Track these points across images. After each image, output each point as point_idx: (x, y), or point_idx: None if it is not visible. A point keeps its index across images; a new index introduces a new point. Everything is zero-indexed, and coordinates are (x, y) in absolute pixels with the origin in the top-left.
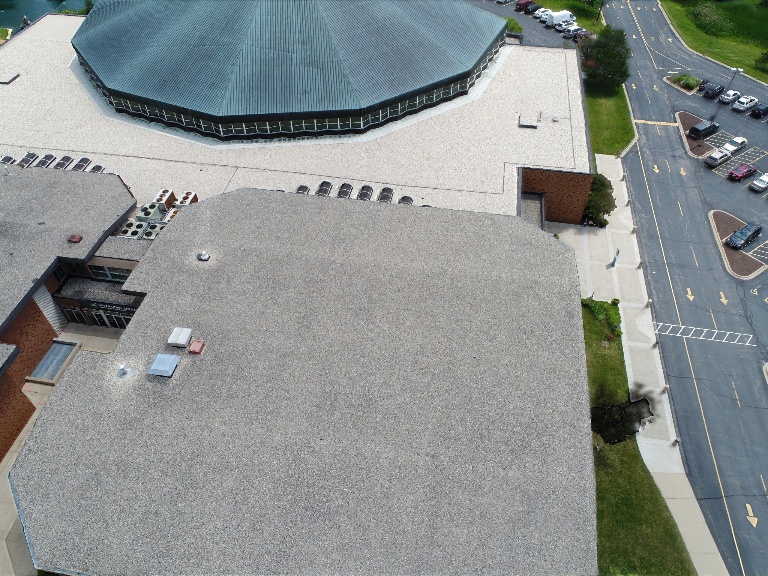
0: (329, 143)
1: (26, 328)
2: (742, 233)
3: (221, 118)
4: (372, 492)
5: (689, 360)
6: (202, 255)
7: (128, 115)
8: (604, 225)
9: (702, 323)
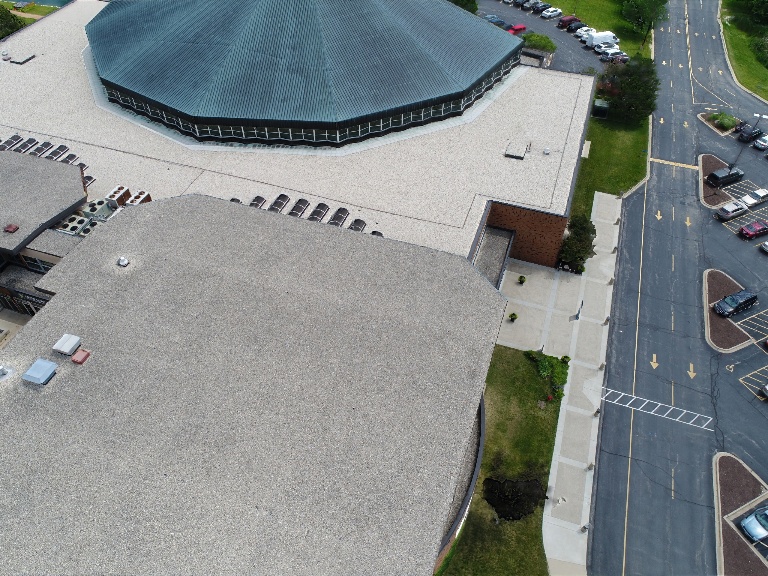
0: (302, 154)
1: None
2: (732, 300)
3: (196, 118)
4: (197, 541)
5: (630, 436)
6: (120, 260)
7: (119, 106)
8: (580, 272)
9: (658, 396)
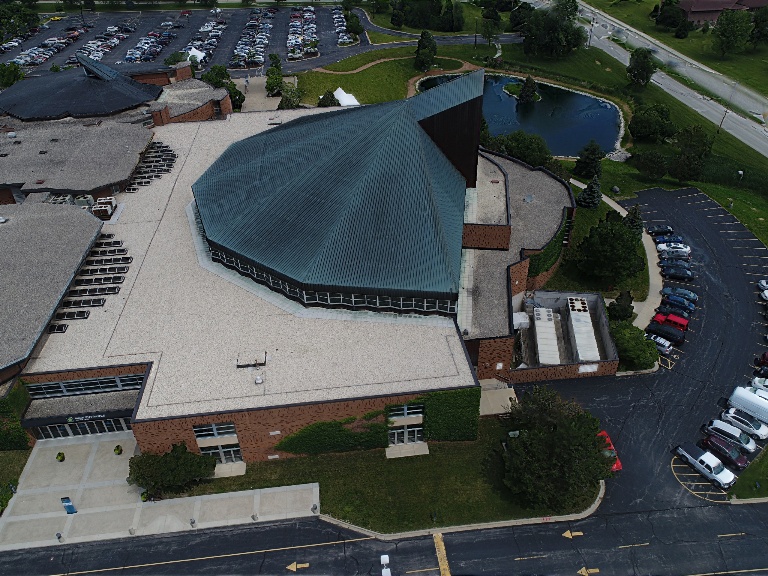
0: (196, 248)
1: (2, 203)
2: None
3: None
4: None
5: None
6: None
7: None
8: None
9: None
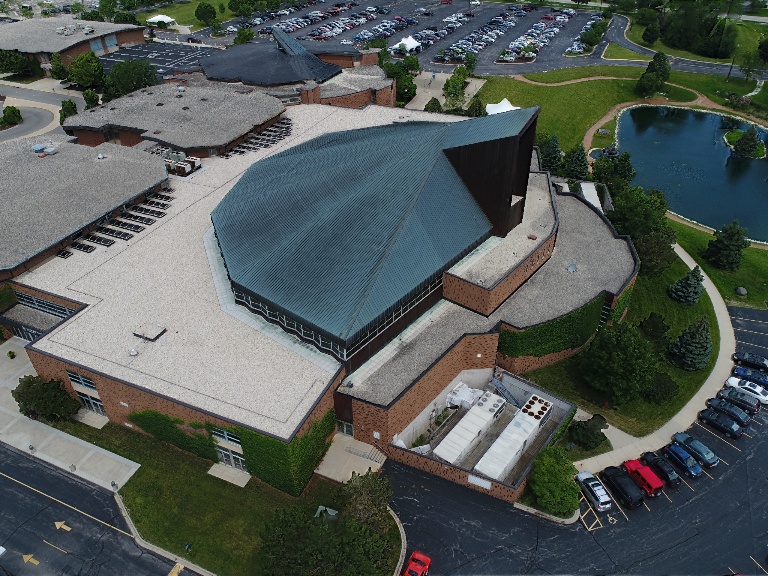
0: None
1: (136, 143)
2: None
3: None
4: None
5: None
6: None
7: None
8: None
9: None
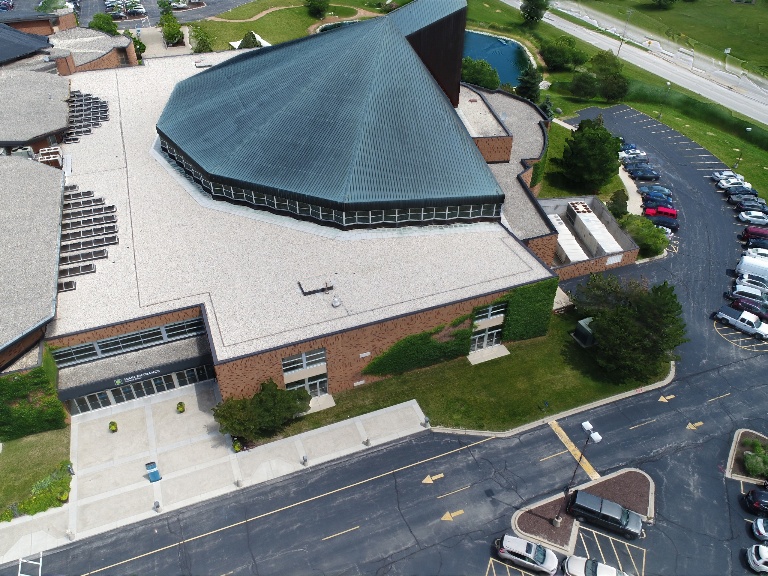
0: (187, 190)
1: None
2: None
3: (157, 129)
4: None
5: None
6: None
7: None
8: None
9: None
